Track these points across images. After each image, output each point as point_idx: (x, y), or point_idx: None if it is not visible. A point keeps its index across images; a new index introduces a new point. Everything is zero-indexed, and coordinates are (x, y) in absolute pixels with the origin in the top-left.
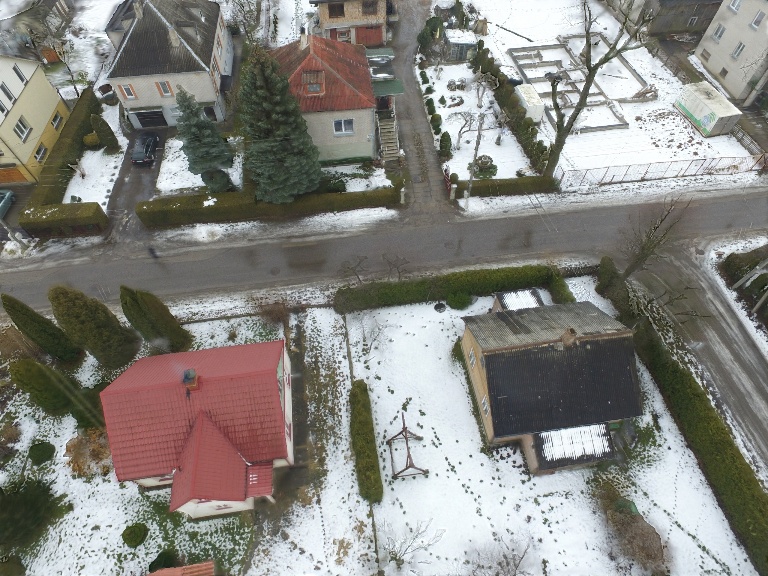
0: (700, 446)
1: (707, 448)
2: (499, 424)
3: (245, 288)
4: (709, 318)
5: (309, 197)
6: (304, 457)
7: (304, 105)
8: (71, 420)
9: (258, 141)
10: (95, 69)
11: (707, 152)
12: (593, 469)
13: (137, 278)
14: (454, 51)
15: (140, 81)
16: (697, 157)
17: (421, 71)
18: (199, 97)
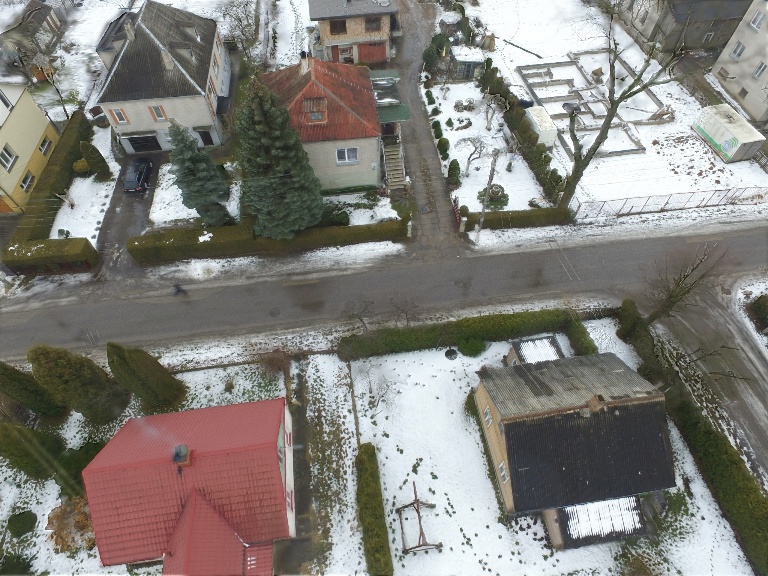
0: (737, 518)
1: (746, 522)
2: (520, 498)
3: (243, 332)
4: (739, 367)
5: (311, 231)
6: (307, 528)
7: (305, 134)
8: (55, 484)
9: (256, 175)
10: (87, 88)
11: (730, 180)
12: (621, 543)
13: (128, 320)
14: (461, 69)
15: (132, 106)
16: (719, 186)
17: (427, 91)
18: (194, 121)
